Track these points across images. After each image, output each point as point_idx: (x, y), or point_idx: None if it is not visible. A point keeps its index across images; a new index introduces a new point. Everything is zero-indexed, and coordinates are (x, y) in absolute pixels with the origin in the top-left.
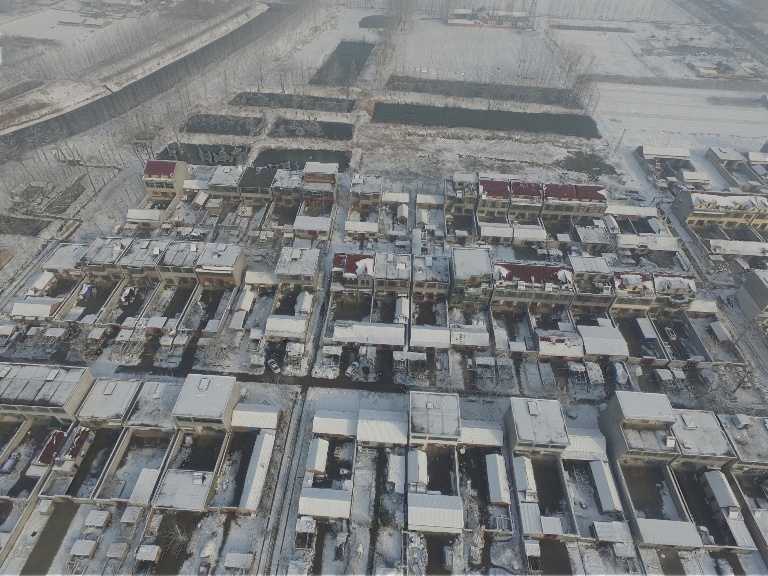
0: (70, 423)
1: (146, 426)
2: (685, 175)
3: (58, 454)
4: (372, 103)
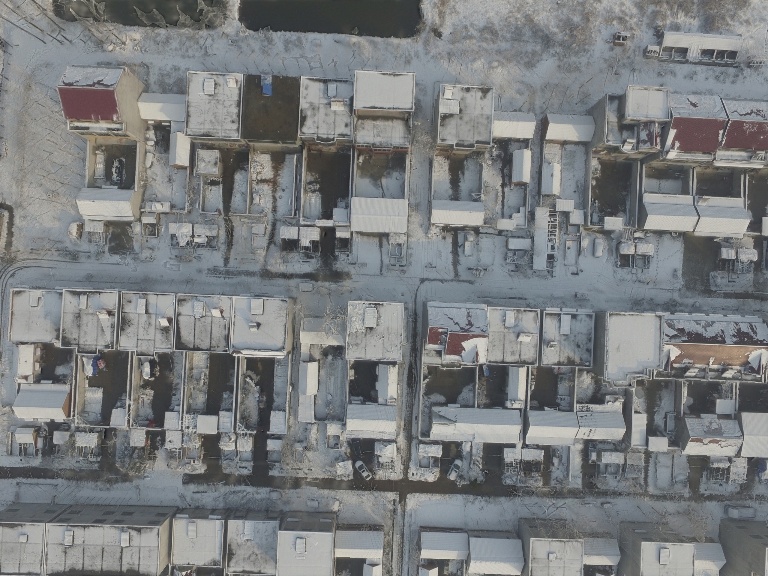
0: None
1: (249, 573)
2: None
3: None
4: None
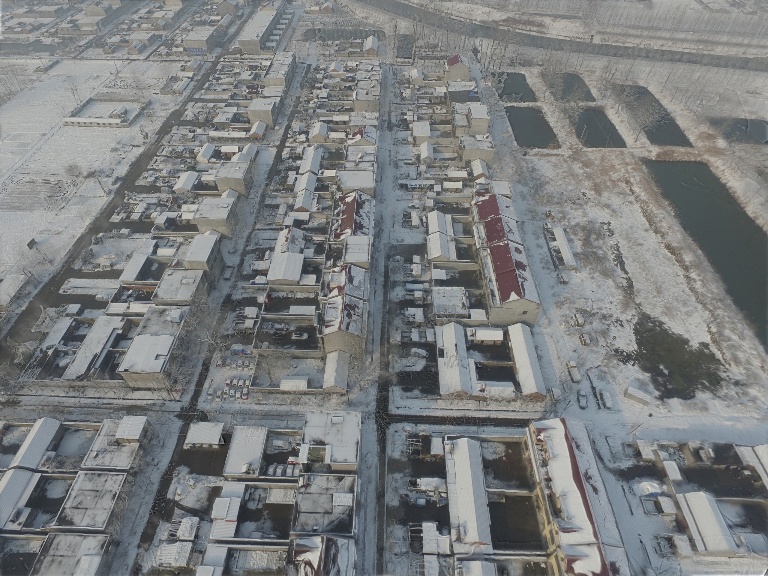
0: None
1: None
2: (693, 495)
3: None
4: (696, 158)
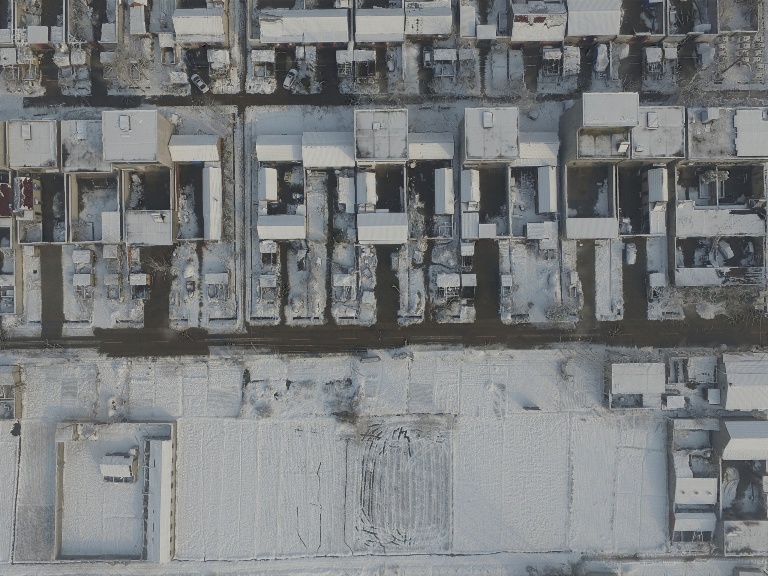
0: (7, 173)
1: (85, 171)
2: None
3: (13, 205)
4: None
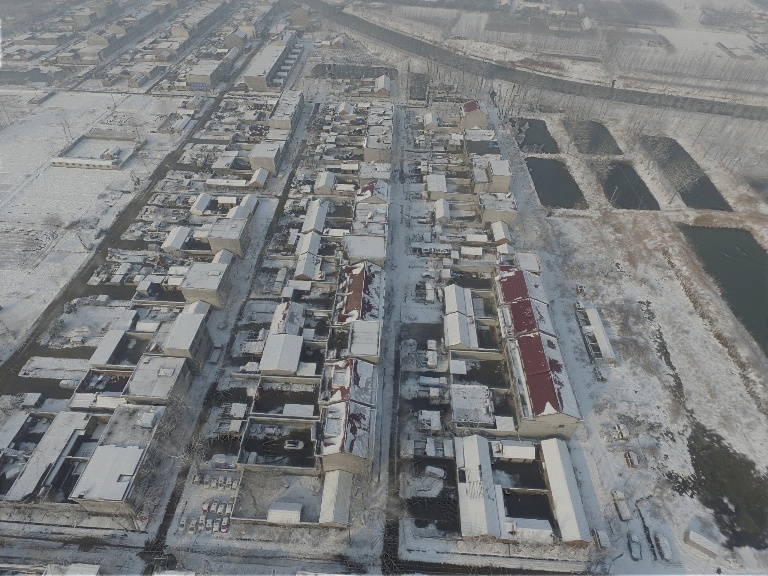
0: None
1: None
2: None
3: None
4: (737, 224)
